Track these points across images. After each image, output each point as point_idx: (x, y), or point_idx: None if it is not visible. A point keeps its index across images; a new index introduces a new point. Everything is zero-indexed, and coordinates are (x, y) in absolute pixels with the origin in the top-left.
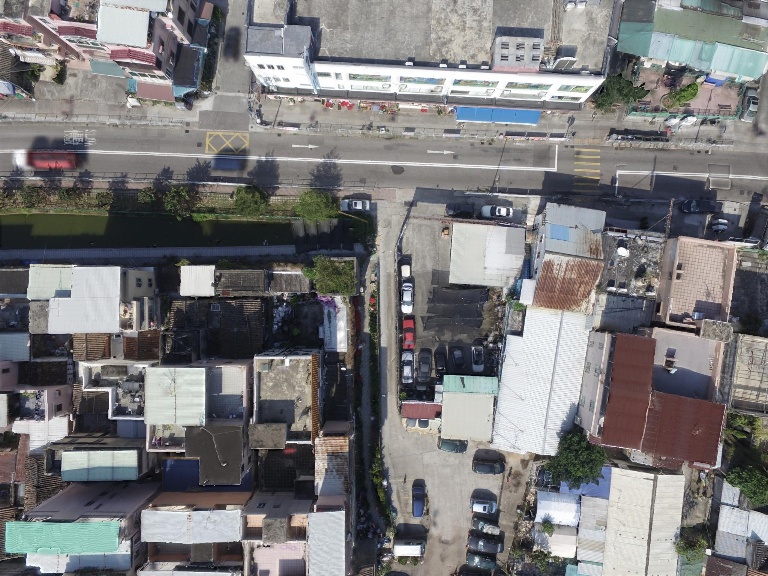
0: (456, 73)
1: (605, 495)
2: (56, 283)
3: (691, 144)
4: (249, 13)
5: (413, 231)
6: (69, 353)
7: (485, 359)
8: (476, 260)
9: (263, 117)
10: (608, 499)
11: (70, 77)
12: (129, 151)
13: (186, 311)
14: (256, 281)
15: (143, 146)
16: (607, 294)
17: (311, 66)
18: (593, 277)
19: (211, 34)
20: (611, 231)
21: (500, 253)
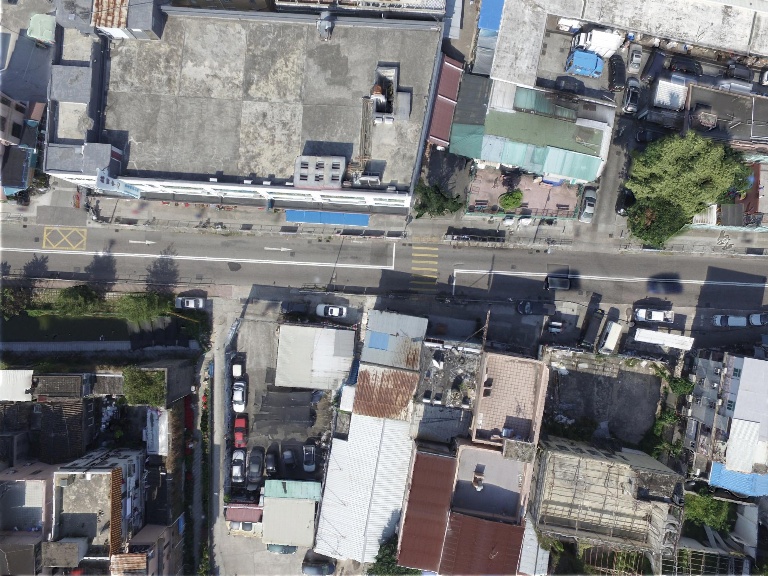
0: None
1: None
2: None
3: (528, 244)
4: (51, 129)
5: (248, 328)
6: None
7: (318, 458)
8: (303, 362)
9: (101, 213)
10: None
11: None
12: None
13: (5, 415)
14: (73, 387)
15: None
16: (424, 404)
17: (116, 181)
18: (410, 387)
19: None
20: (428, 342)
21: (328, 355)
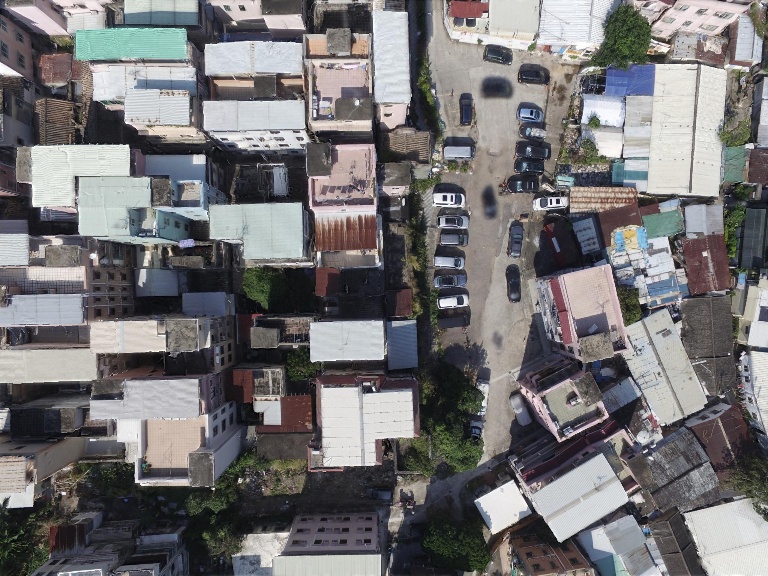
0: None
1: (649, 92)
2: None
3: None
4: None
5: None
6: None
7: None
8: None
9: None
10: (653, 95)
11: None
12: None
13: None
14: None
15: None
16: None
17: None
18: None
19: None
20: None
21: None
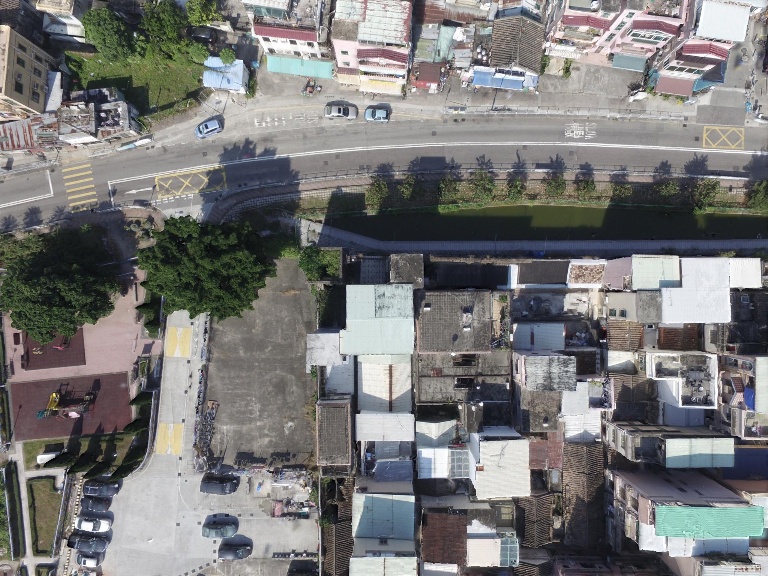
0: None
1: None
2: (659, 273)
3: None
4: None
5: None
6: (597, 343)
7: None
8: None
9: (759, 112)
10: None
11: (573, 70)
12: (628, 144)
13: None
14: None
15: (642, 139)
16: None
17: None
18: None
19: None
20: None
21: None
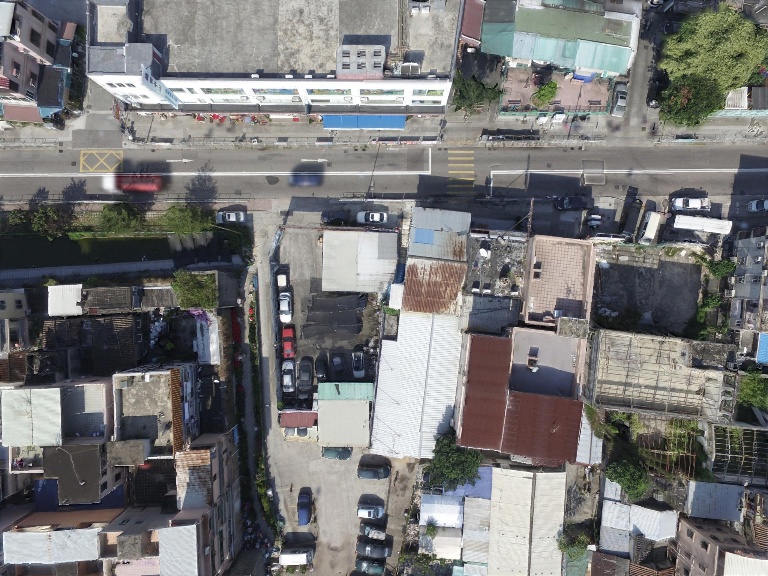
0: (303, 83)
1: (487, 495)
2: None
3: (563, 141)
4: (91, 33)
5: (290, 240)
6: None
7: (367, 365)
8: (348, 267)
9: (136, 134)
10: (490, 499)
11: None
12: (4, 173)
13: (56, 331)
14: (123, 298)
15: (18, 168)
16: (473, 295)
17: (158, 83)
18: (458, 279)
19: (79, 54)
20: (473, 233)
21: (372, 259)
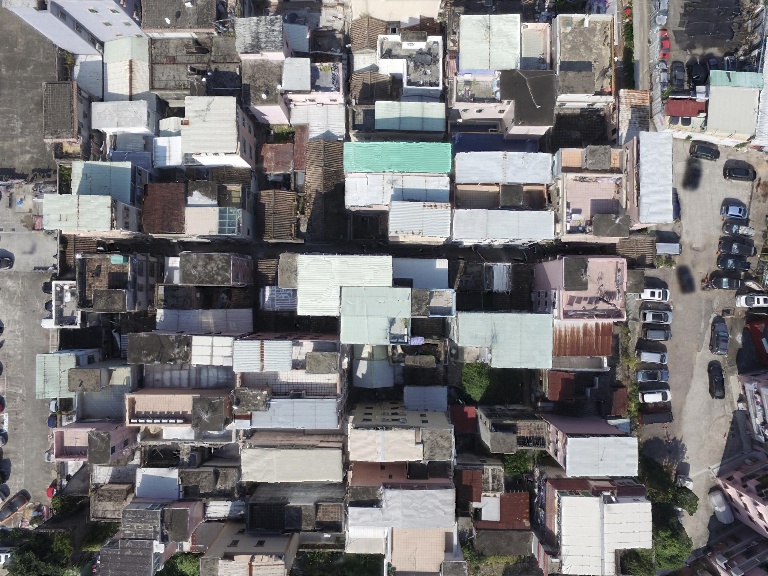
0: None
1: None
2: None
3: None
4: None
5: None
6: (344, 49)
7: None
8: None
9: None
10: None
11: None
12: None
13: None
14: None
15: None
16: None
17: None
18: None
19: None
20: None
21: None
